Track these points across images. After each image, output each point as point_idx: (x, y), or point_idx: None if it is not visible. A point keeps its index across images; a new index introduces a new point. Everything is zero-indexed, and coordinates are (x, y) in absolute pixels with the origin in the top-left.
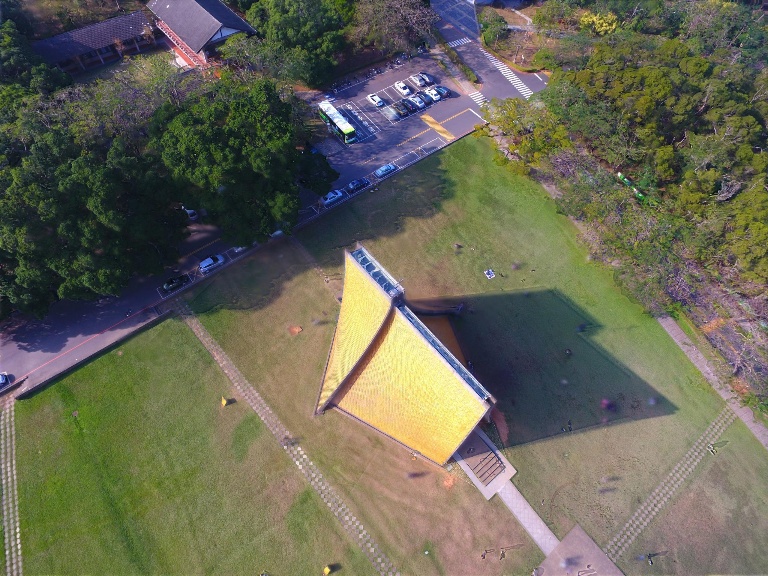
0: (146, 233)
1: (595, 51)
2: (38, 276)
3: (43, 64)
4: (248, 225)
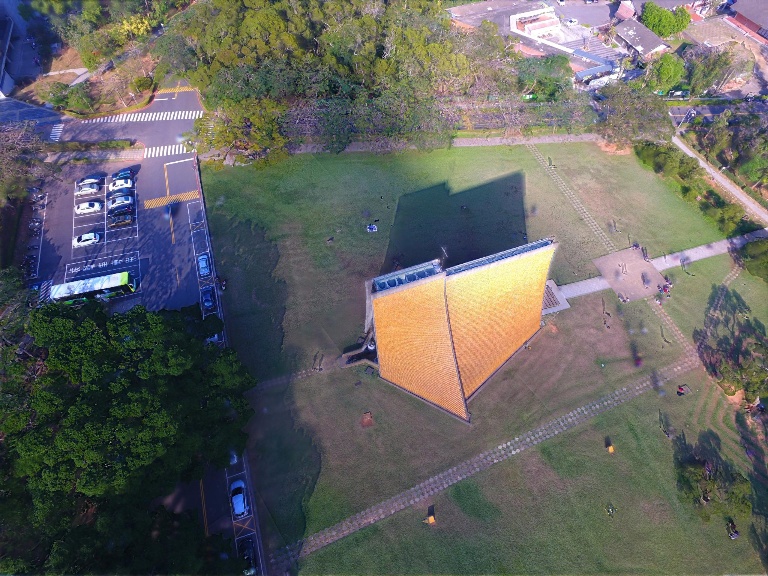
0: None
1: (194, 38)
2: None
3: None
4: (225, 424)
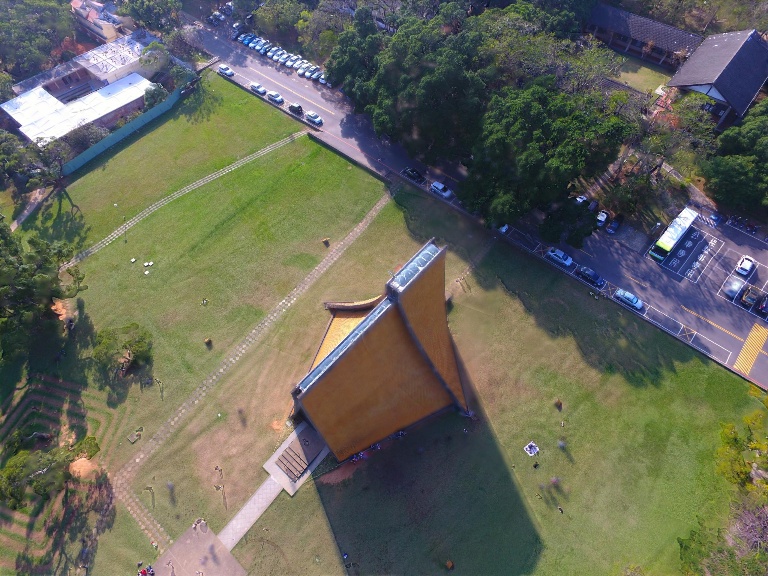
0: (428, 126)
1: None
2: (372, 90)
3: (573, 13)
4: (477, 191)
